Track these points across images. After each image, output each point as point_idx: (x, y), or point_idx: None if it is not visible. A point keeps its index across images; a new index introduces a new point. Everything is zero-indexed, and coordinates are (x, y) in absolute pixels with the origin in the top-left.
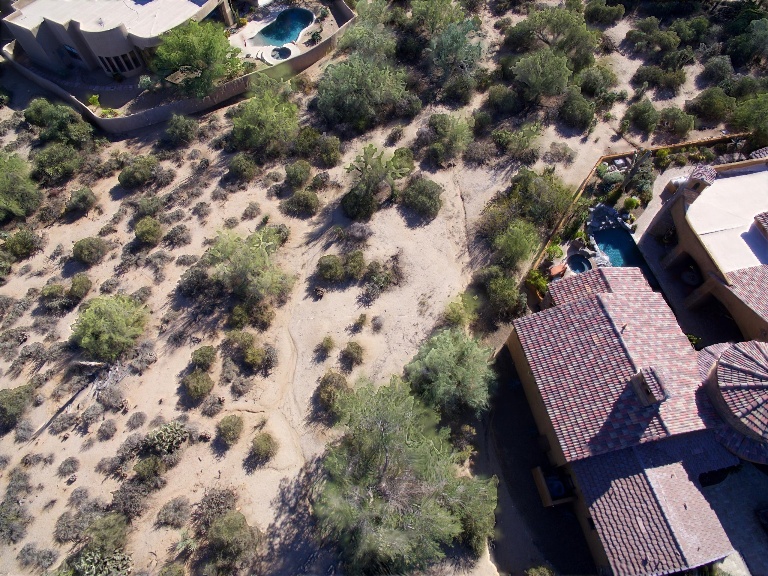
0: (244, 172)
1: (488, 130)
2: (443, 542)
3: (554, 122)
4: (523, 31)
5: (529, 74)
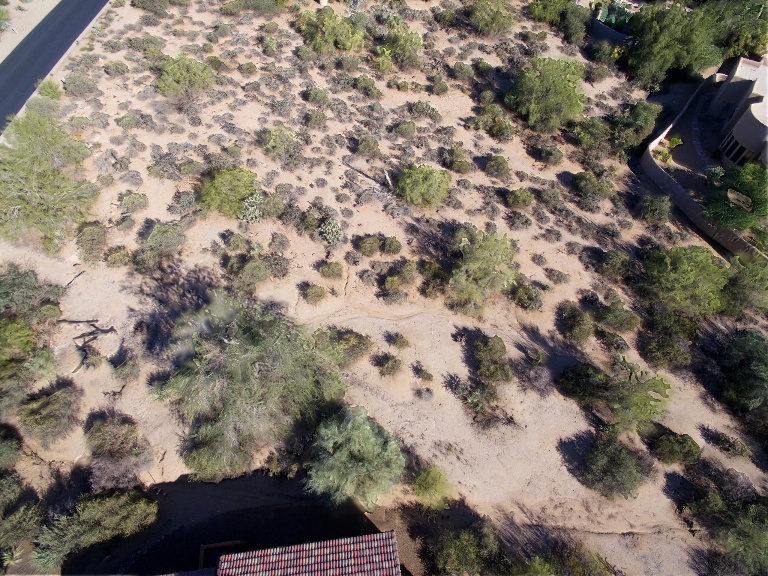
0: (605, 263)
1: None
2: (198, 420)
3: None
4: None
5: None
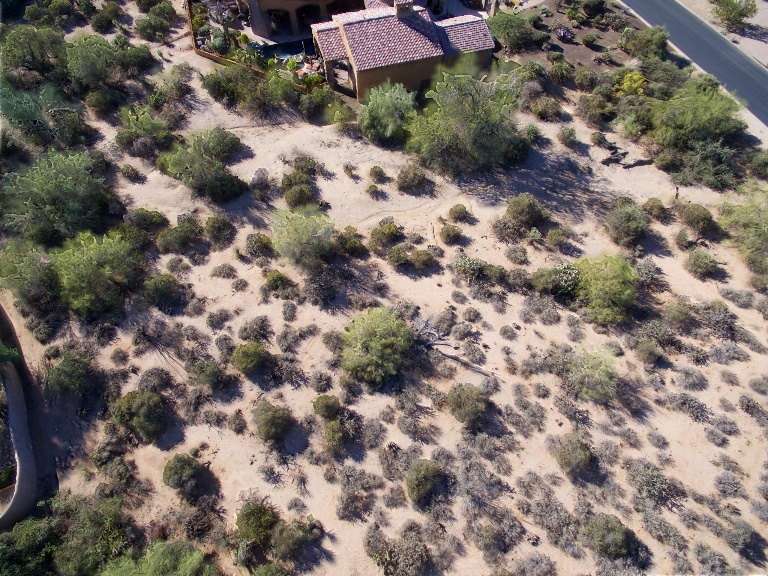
0: (171, 281)
1: None
2: None
3: (142, 76)
4: (9, 79)
5: (96, 62)
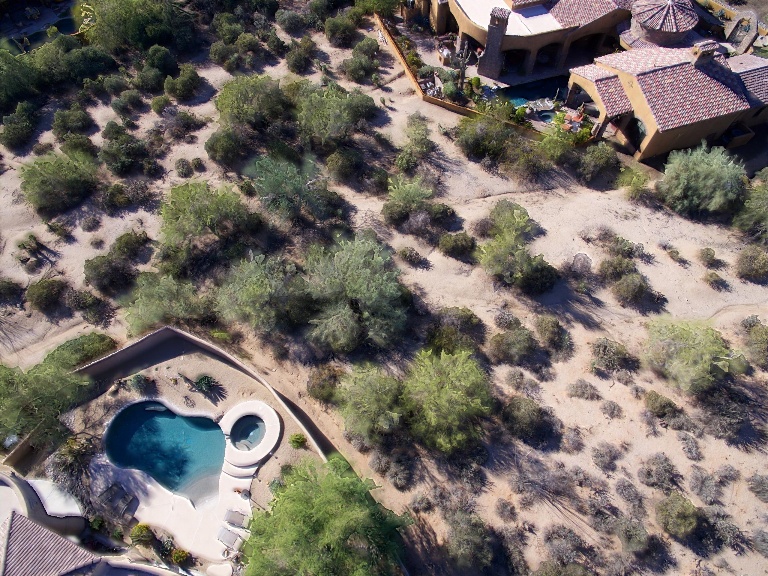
0: (538, 409)
1: None
2: None
3: (369, 128)
4: (232, 138)
5: None
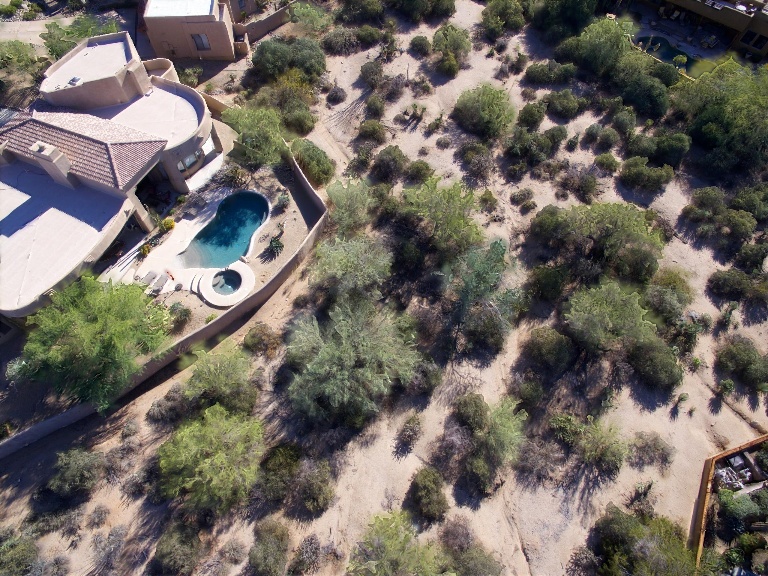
0: (181, 570)
1: (539, 406)
2: None
3: (626, 380)
4: (558, 225)
5: (595, 333)
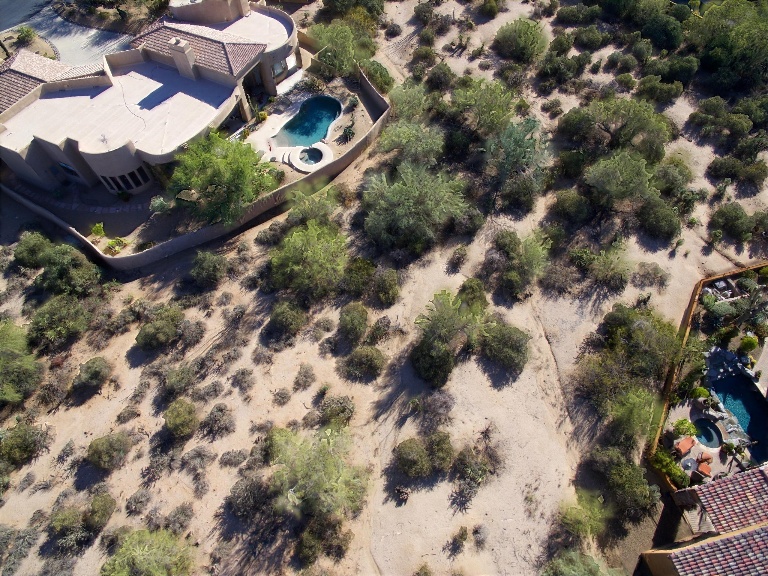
0: (290, 326)
1: (562, 246)
2: None
3: (634, 232)
4: (581, 120)
5: (608, 184)
